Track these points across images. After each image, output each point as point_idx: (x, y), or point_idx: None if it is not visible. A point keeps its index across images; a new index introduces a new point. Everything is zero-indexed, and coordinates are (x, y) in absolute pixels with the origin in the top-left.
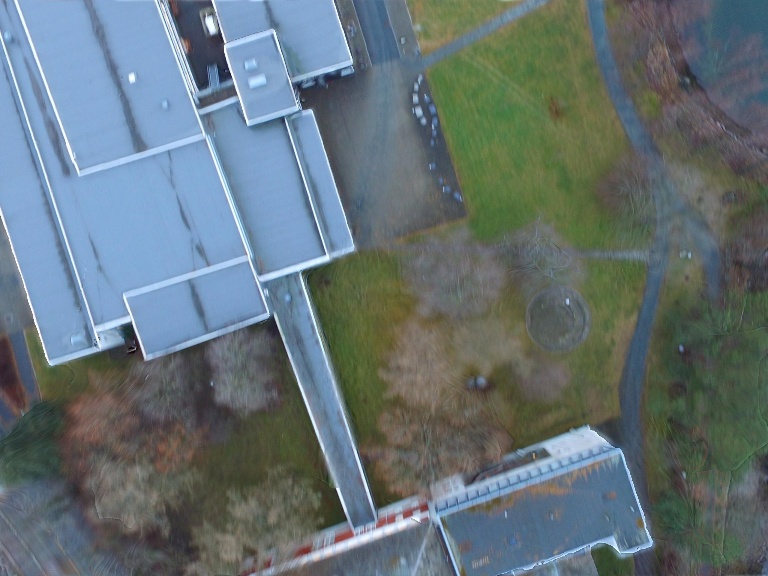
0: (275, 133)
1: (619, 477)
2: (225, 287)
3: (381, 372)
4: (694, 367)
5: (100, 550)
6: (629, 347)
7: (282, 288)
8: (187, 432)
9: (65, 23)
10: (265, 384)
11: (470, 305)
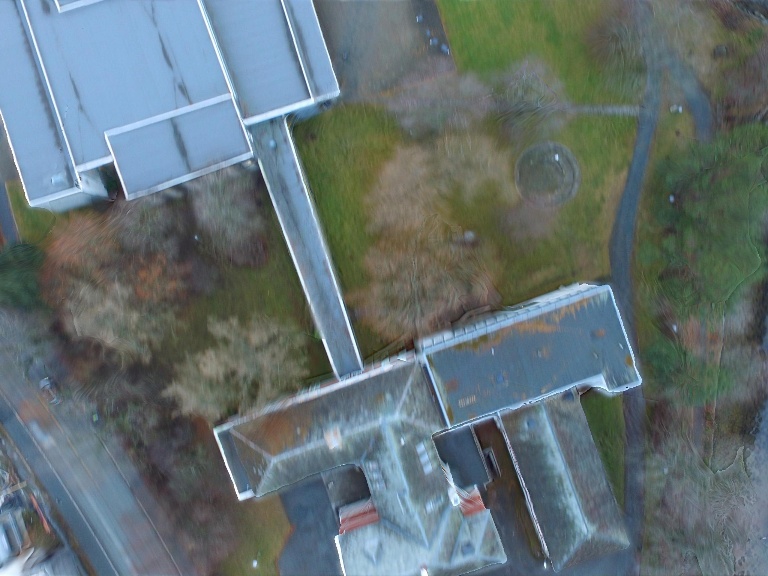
0: None
1: (608, 314)
2: (208, 126)
3: (368, 228)
4: (684, 208)
5: (80, 377)
6: (619, 204)
7: (267, 135)
8: (169, 264)
9: None
10: (250, 237)
11: (458, 160)
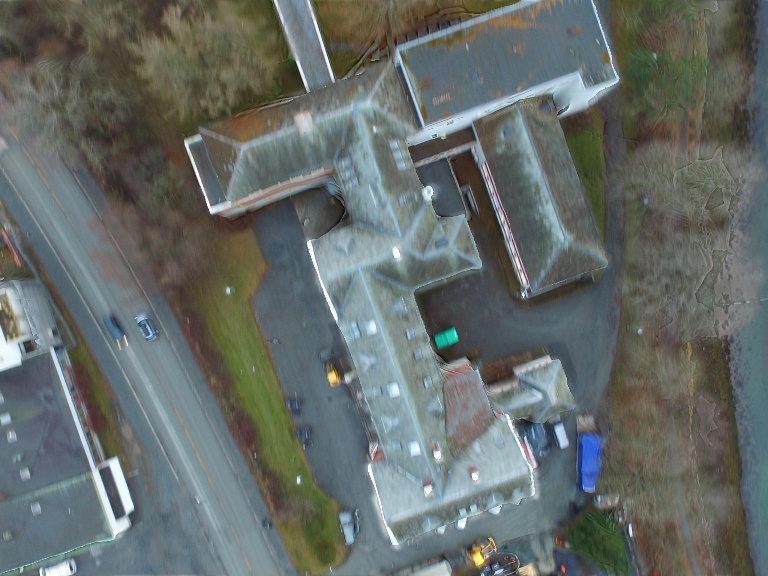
0: None
1: (584, 10)
2: None
3: None
4: None
5: (45, 53)
6: None
7: None
8: None
9: None
10: None
11: None
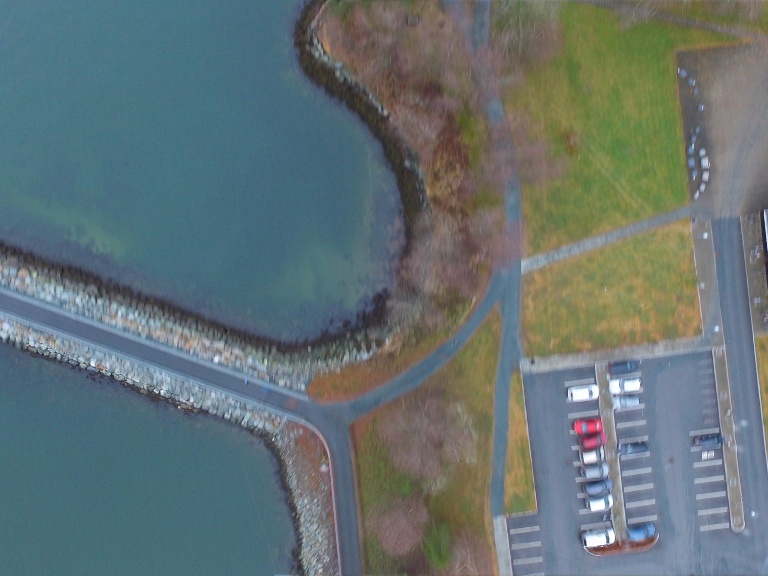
0: None
1: None
2: None
3: None
4: None
5: None
6: None
7: None
8: None
9: None
10: None
11: None
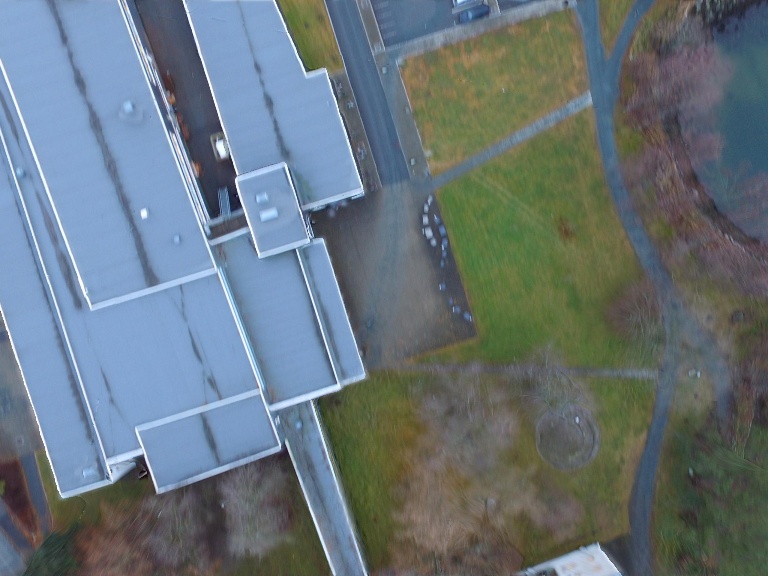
0: (286, 262)
1: None
2: (237, 420)
3: (391, 492)
4: (704, 498)
5: None
6: (638, 465)
7: (293, 414)
8: (200, 572)
9: (77, 158)
10: (276, 507)
11: (480, 424)
